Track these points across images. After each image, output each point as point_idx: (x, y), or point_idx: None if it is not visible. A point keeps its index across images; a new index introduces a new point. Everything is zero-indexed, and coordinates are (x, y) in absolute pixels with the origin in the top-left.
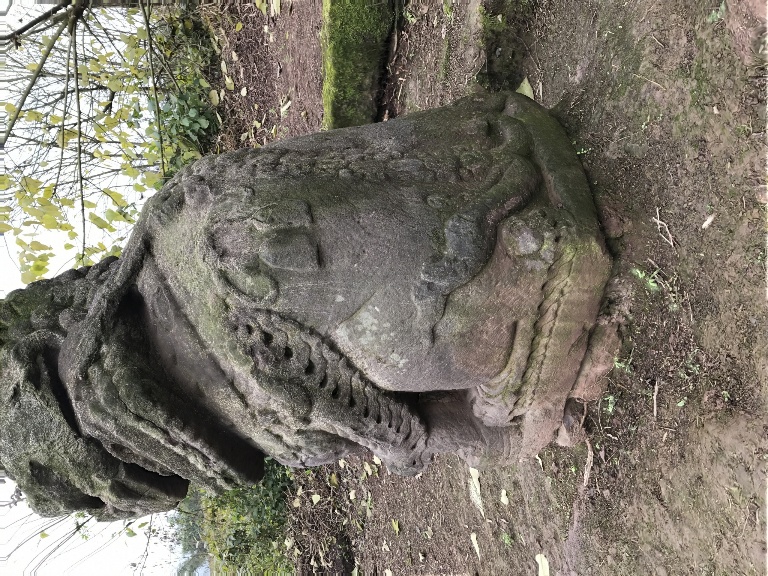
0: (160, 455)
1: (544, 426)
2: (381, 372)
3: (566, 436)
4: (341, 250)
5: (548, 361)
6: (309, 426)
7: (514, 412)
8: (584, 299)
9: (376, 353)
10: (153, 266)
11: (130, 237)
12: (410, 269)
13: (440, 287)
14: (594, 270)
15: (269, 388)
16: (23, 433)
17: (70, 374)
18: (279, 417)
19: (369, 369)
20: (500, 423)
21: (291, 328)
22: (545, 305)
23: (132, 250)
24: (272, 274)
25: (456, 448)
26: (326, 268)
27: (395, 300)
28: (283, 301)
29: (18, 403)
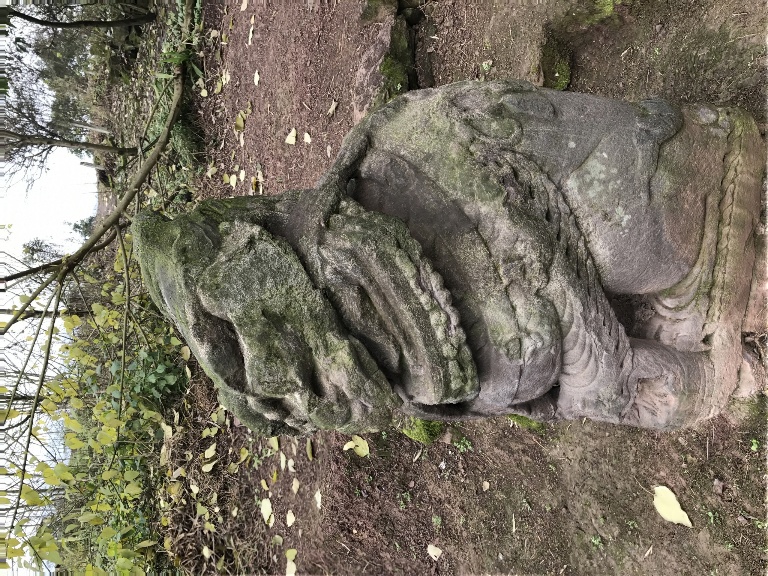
0: (409, 300)
1: (730, 356)
2: (604, 235)
3: (749, 376)
4: (567, 106)
5: (730, 258)
6: (545, 289)
7: (705, 328)
8: (751, 185)
9: (603, 207)
10: (380, 150)
11: (347, 142)
12: (628, 119)
13: (655, 134)
14: (756, 152)
15: (520, 222)
16: (258, 277)
17: (311, 222)
18: (525, 263)
19: (592, 234)
20: (695, 342)
21: (534, 167)
22: (724, 185)
23: (356, 142)
24: (515, 118)
25: (660, 371)
26: (558, 118)
27: (620, 144)
28: (526, 142)
29: (253, 250)
